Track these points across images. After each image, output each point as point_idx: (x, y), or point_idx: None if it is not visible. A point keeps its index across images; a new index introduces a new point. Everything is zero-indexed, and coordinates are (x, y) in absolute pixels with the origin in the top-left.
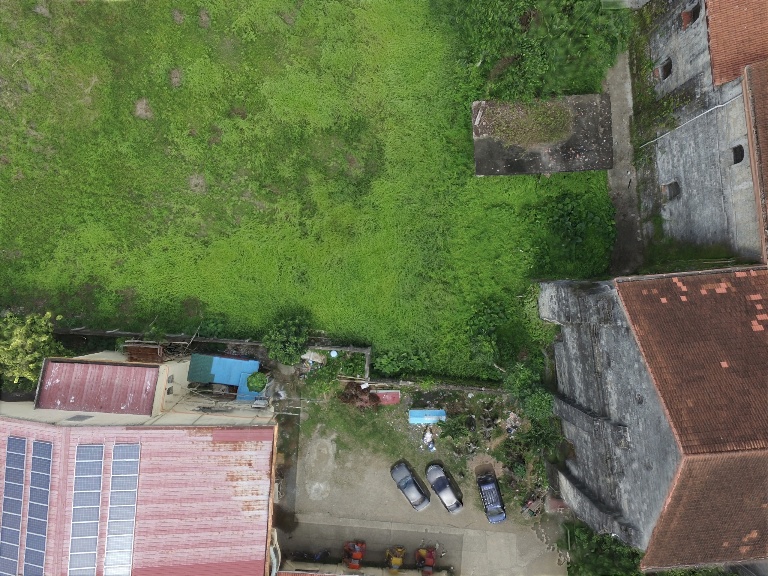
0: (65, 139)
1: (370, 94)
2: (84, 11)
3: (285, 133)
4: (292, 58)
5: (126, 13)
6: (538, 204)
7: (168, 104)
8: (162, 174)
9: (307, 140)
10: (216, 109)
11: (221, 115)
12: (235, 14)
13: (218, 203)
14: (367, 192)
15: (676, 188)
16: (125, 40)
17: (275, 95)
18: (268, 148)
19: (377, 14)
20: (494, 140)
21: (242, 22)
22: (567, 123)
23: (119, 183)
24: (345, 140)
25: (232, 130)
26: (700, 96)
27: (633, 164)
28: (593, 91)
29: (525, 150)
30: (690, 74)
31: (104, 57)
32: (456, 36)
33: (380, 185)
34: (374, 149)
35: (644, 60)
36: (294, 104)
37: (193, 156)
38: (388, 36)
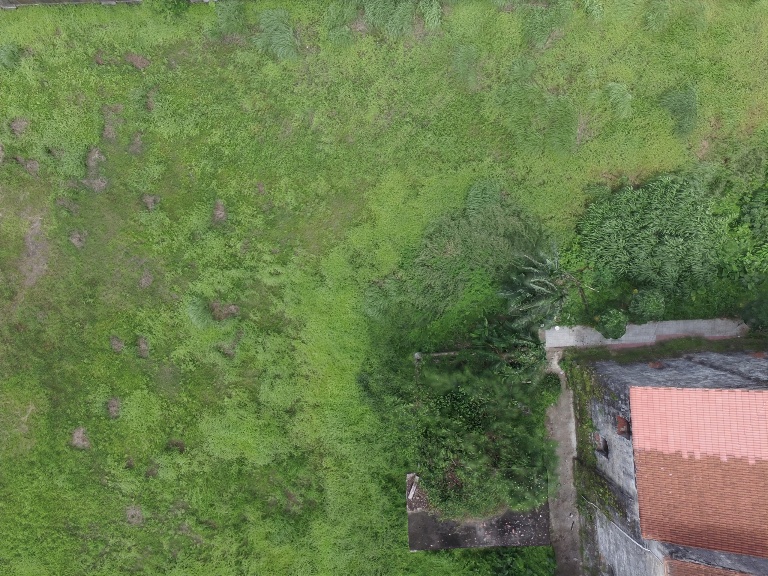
0: (1, 470)
1: (309, 432)
2: (22, 339)
3: (223, 468)
4: (231, 390)
5: (64, 341)
6: (478, 549)
7: (105, 434)
8: (98, 506)
9: (245, 476)
10: (153, 441)
11: (158, 449)
12: (174, 343)
13: (154, 536)
14: (304, 532)
15: (612, 573)
16: (63, 368)
17: (212, 433)
18: (205, 483)
19: (317, 348)
20: (428, 514)
21: (181, 353)
22: (502, 499)
23: (55, 514)
24: (283, 477)
25: (169, 466)
26: (630, 522)
27: (576, 506)
28: (535, 437)
29: (459, 525)
30: (623, 483)
31: (41, 385)
32: (396, 375)
33: (318, 526)
34: (312, 488)
35: (585, 417)
36: (231, 443)
37: (129, 489)
38: (328, 370)
